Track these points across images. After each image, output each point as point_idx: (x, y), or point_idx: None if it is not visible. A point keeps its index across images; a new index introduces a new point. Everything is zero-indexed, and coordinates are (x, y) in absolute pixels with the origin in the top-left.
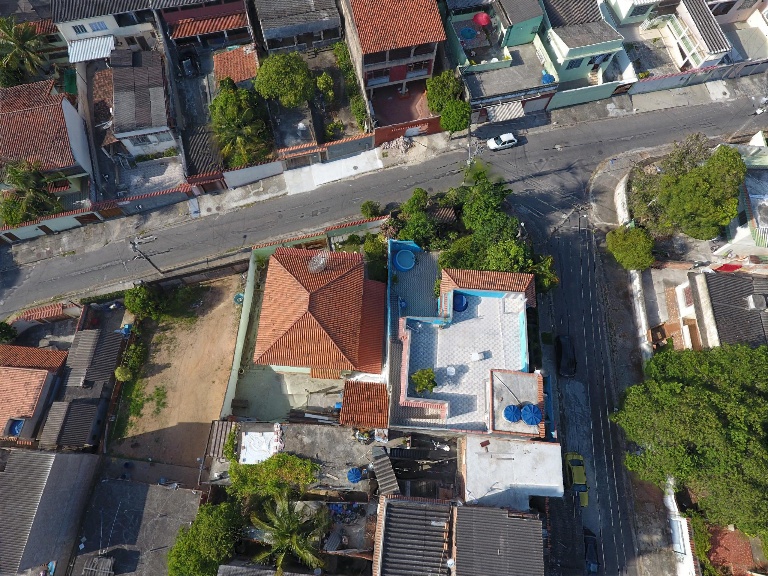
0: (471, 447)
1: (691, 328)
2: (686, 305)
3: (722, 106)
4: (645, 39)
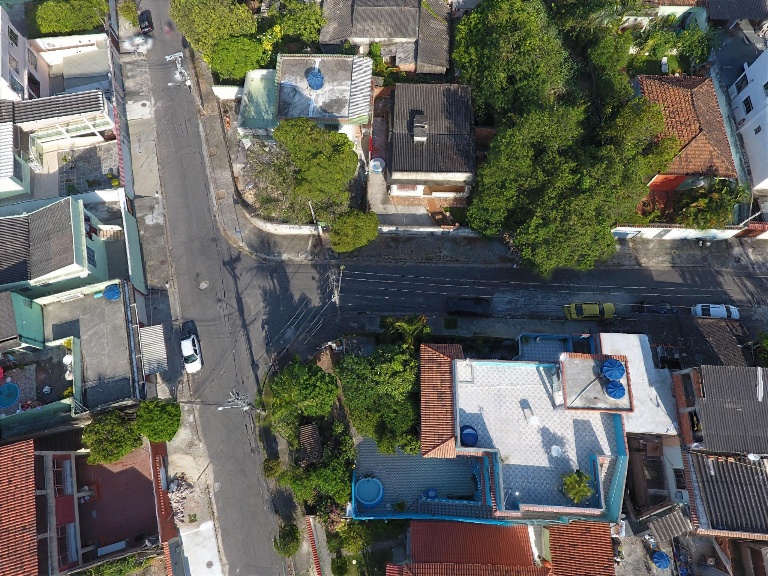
0: None
1: (432, 189)
2: (414, 190)
3: (160, 110)
4: (57, 169)
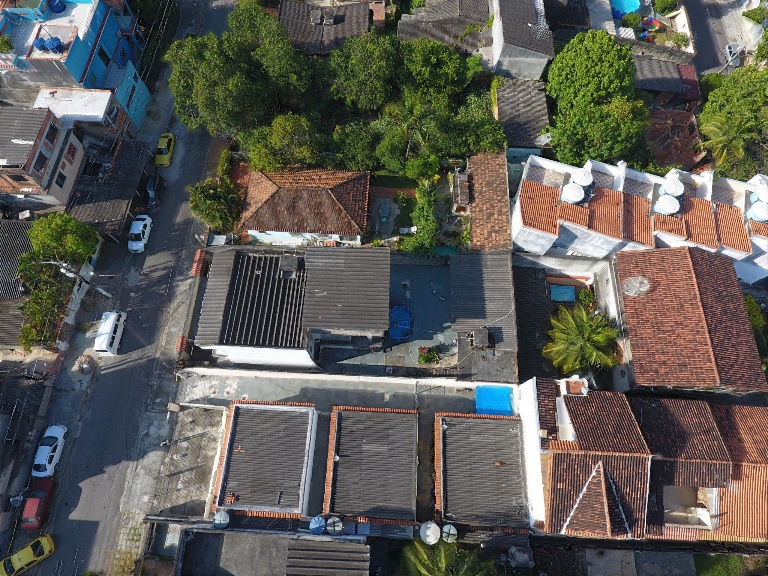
0: (41, 95)
1: None
2: None
3: None
4: None
